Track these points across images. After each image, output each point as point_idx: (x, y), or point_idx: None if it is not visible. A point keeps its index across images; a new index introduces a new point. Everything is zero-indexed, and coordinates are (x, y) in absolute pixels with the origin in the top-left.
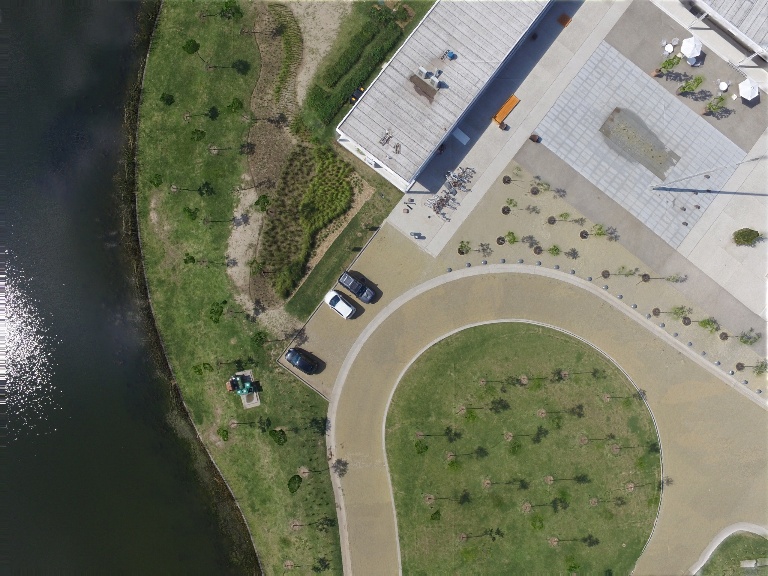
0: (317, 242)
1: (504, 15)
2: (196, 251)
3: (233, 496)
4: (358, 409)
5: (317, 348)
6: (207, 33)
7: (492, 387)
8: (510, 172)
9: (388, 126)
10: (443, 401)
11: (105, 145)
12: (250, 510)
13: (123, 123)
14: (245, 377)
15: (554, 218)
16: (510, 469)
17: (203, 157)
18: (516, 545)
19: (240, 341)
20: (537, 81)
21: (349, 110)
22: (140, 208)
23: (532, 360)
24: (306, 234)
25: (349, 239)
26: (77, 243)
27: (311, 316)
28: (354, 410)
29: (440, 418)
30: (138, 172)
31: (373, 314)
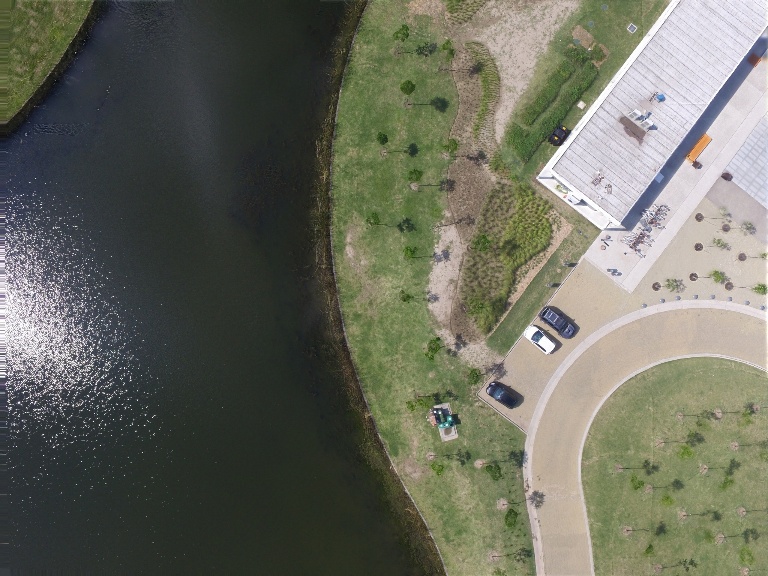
0: (517, 278)
1: (710, 58)
2: (395, 286)
3: (427, 526)
4: (555, 442)
5: (515, 382)
6: (403, 70)
7: (688, 421)
8: (703, 209)
9: (599, 167)
10: (642, 435)
11: (297, 179)
12: (444, 540)
13: (315, 158)
14: (443, 410)
15: (744, 255)
16: (704, 501)
17: (403, 193)
18: (708, 575)
19: (438, 375)
20: (728, 120)
21: (547, 148)
22: (335, 242)
23: (725, 394)
24: (508, 270)
25: (549, 275)
26: (270, 276)
27: (510, 351)
28: (551, 443)
29: (639, 451)
30: (333, 207)
31: (570, 349)
